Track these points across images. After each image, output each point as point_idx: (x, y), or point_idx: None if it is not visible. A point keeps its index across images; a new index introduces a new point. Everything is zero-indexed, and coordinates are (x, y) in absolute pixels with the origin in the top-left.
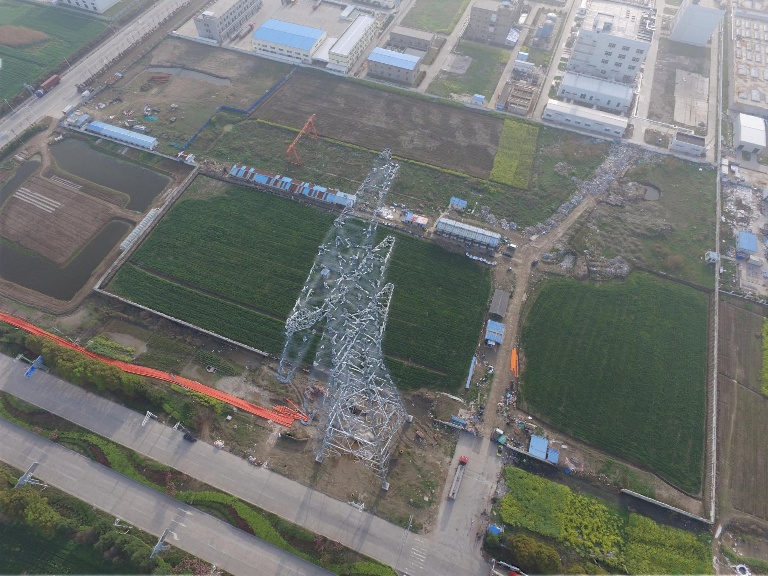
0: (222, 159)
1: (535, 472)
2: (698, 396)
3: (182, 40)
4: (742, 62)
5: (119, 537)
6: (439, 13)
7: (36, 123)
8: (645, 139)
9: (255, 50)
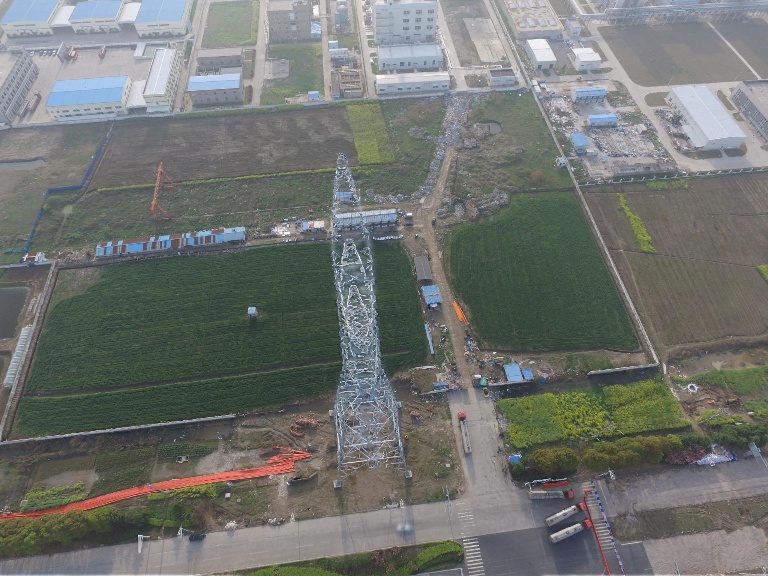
0: (78, 244)
1: (520, 395)
2: (604, 274)
3: None
4: None
5: None
6: (235, 26)
7: None
8: (468, 84)
9: (56, 119)
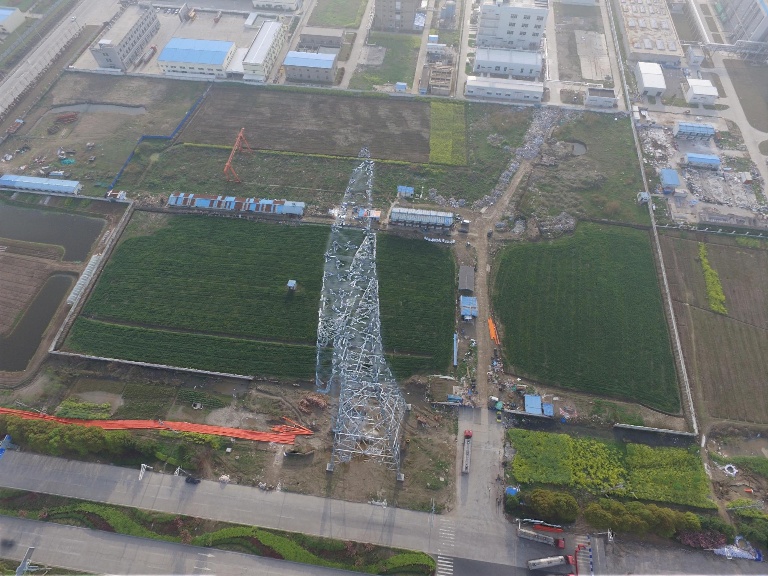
0: (156, 190)
1: (535, 428)
2: (660, 325)
3: (82, 74)
4: (630, 15)
5: None
6: (343, 8)
7: None
8: (562, 99)
9: (164, 73)
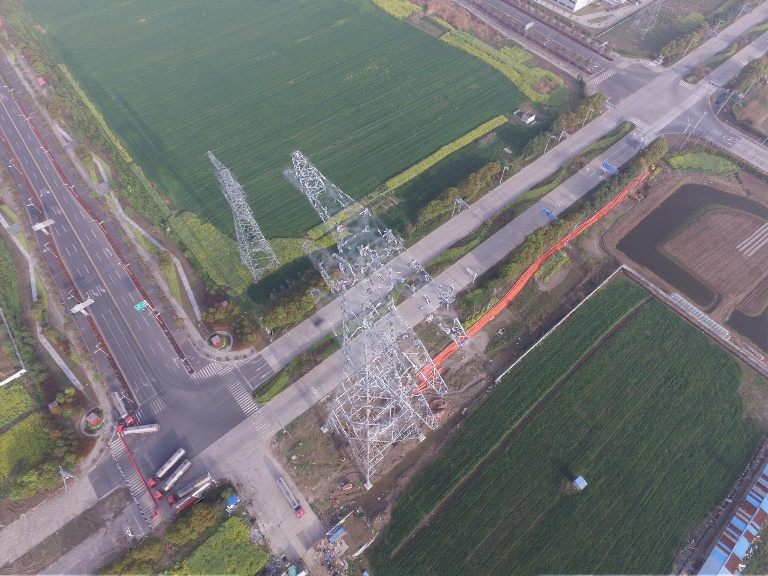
0: None
1: None
2: None
3: None
4: None
5: None
6: None
7: None
8: None
9: None
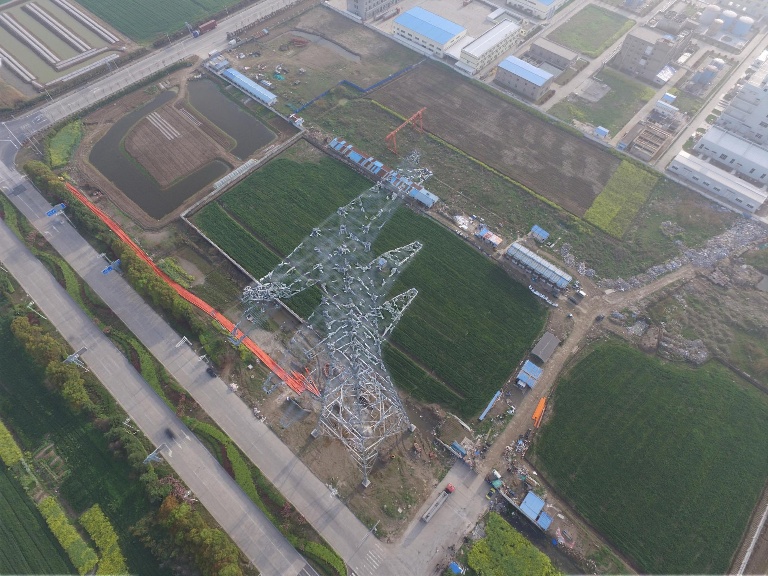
0: (327, 129)
1: (520, 529)
2: (738, 522)
3: (331, 11)
4: None
5: (125, 435)
6: (592, 34)
7: (184, 59)
8: None
9: (393, 34)
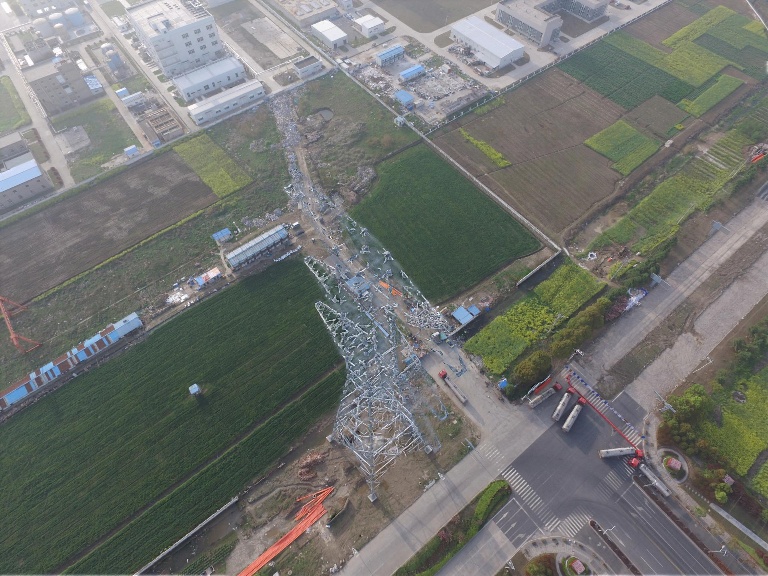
0: None
1: (477, 330)
2: (484, 199)
3: None
4: None
5: None
6: None
7: None
8: (280, 84)
9: None
